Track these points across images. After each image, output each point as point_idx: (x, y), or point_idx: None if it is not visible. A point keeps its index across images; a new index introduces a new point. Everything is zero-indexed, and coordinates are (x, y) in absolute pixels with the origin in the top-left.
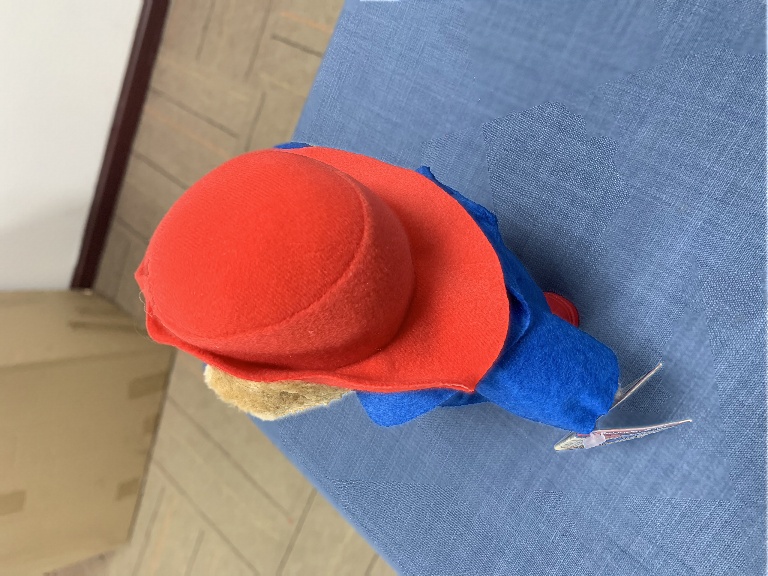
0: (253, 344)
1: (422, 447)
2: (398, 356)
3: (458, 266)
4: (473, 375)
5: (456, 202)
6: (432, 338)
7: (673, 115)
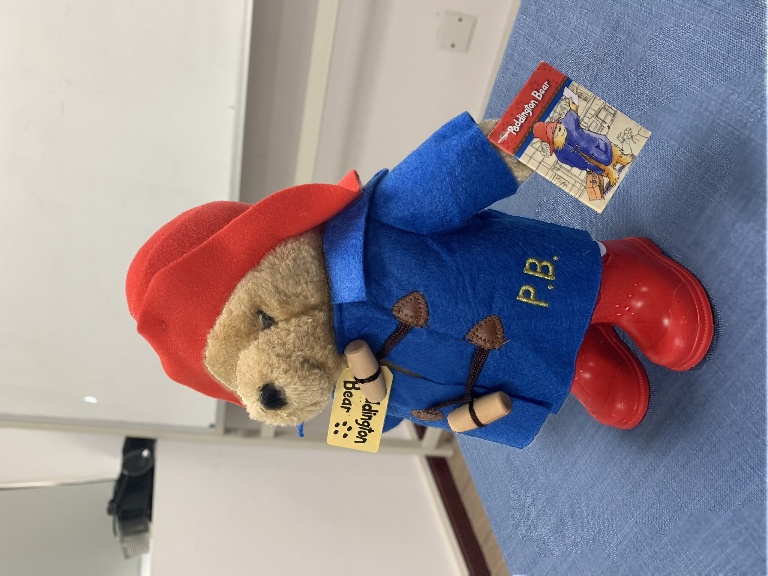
0: (162, 252)
1: None
2: None
3: None
4: None
5: None
6: None
7: None
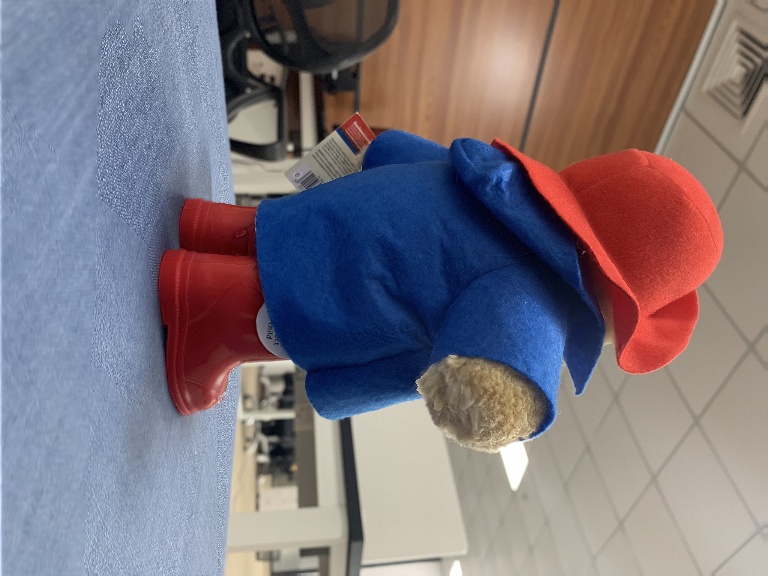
0: None
1: None
2: None
3: None
4: None
5: None
6: None
7: None
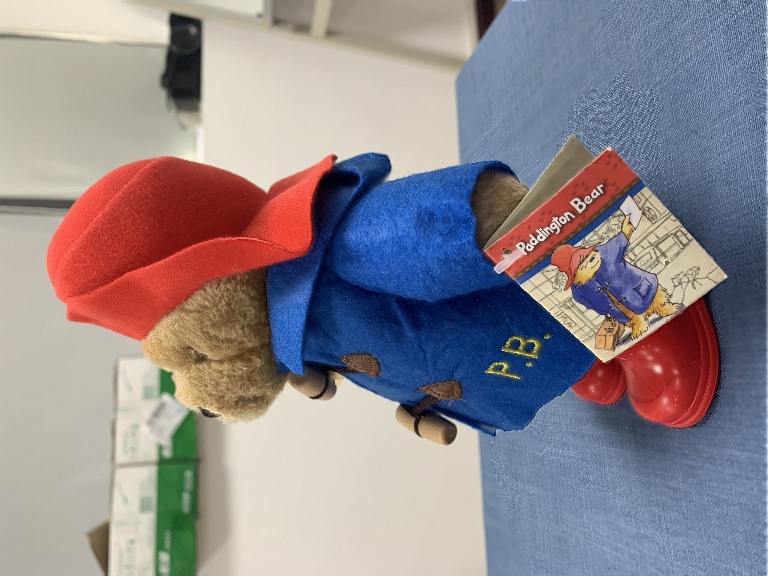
0: (74, 266)
1: (661, 568)
2: None
3: None
4: (301, 244)
5: None
6: (264, 235)
7: (642, 2)
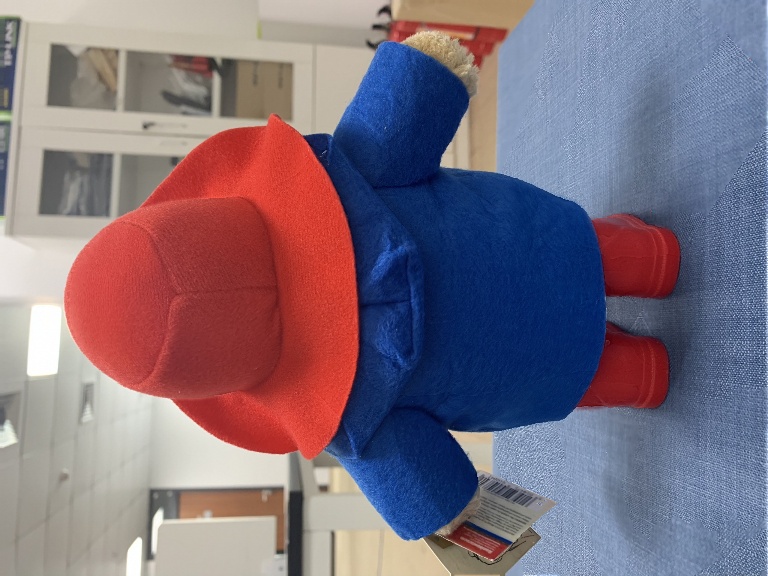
0: None
1: None
2: (247, 398)
3: (310, 389)
4: None
5: (354, 337)
6: (273, 408)
7: None
